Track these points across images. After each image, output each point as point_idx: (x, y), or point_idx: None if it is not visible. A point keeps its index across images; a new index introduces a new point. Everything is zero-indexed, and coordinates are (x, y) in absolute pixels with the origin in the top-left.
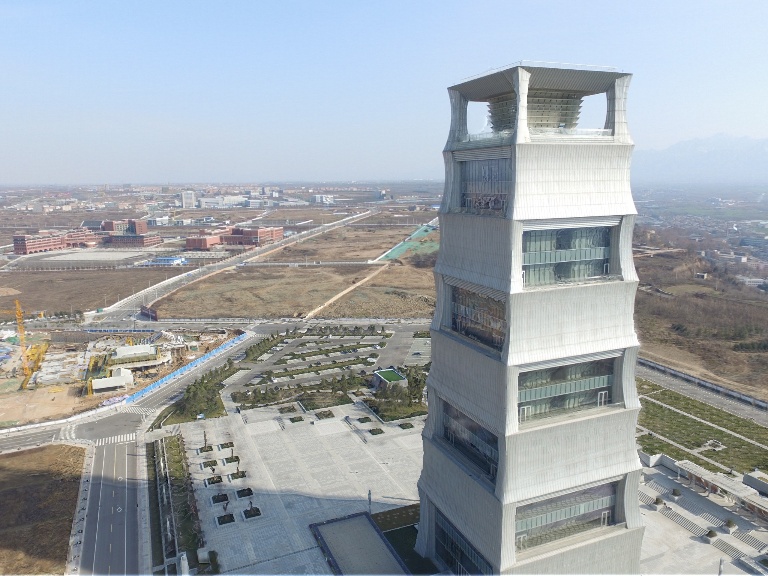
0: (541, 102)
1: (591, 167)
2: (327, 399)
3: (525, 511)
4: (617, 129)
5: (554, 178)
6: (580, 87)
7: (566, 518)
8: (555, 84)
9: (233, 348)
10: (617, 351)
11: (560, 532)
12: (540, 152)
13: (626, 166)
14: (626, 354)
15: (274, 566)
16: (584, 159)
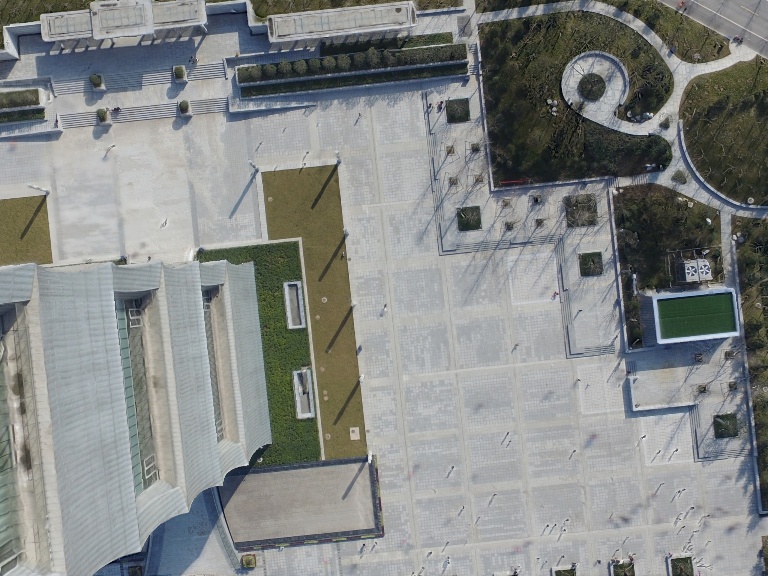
0: None
1: None
2: None
3: None
4: None
5: None
6: None
7: None
8: None
9: None
10: None
11: None
12: None
13: None
14: None
15: None
16: None
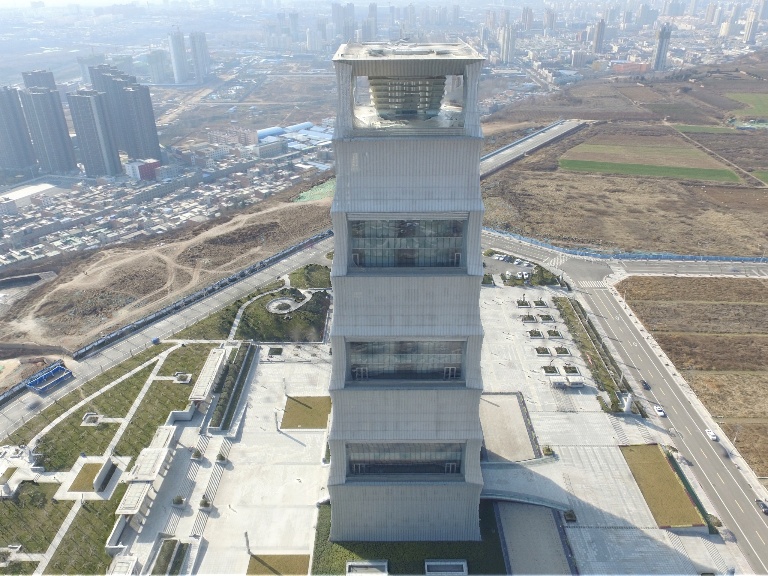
0: None
1: None
2: None
3: None
4: None
5: None
6: None
7: None
8: None
9: None
10: None
11: None
12: None
13: None
14: None
15: (631, 571)
16: None
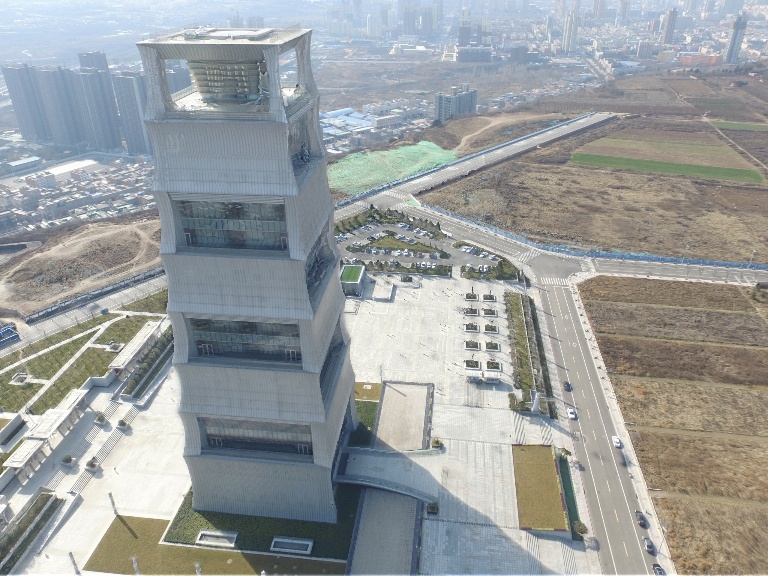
0: None
1: None
2: None
3: None
4: None
5: None
6: None
7: None
8: None
9: None
10: None
11: None
12: None
13: None
14: None
15: (473, 568)
16: None
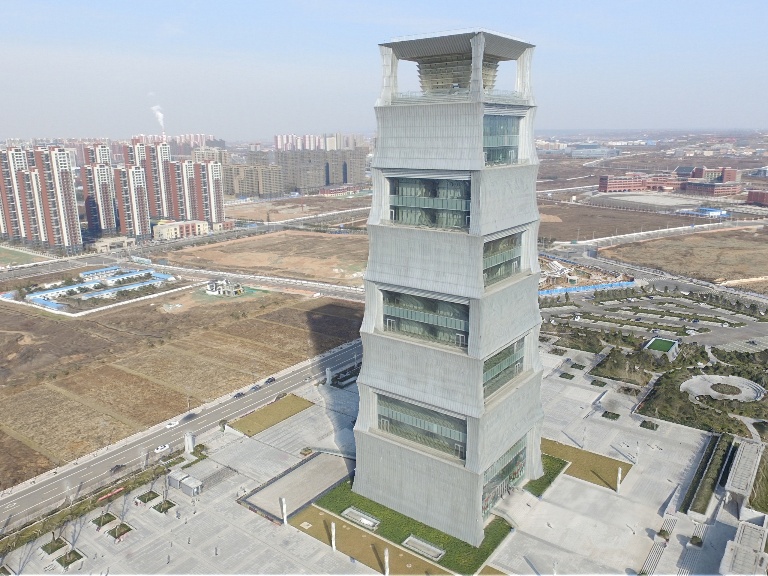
0: (434, 67)
1: (439, 125)
2: (580, 343)
3: (390, 402)
4: (472, 87)
5: (406, 134)
6: (444, 51)
7: (421, 428)
8: (420, 52)
9: (604, 290)
10: (464, 299)
11: (426, 441)
12: (393, 113)
13: (476, 123)
14: (471, 304)
15: None
16: (432, 118)
